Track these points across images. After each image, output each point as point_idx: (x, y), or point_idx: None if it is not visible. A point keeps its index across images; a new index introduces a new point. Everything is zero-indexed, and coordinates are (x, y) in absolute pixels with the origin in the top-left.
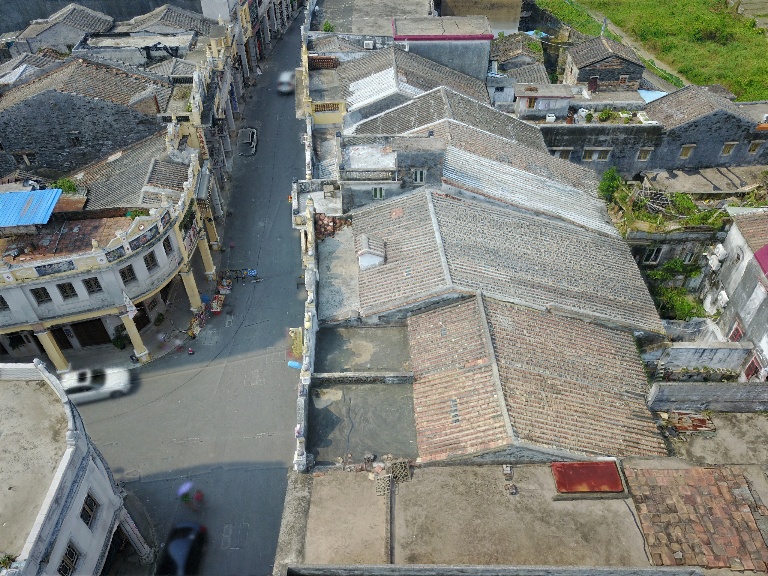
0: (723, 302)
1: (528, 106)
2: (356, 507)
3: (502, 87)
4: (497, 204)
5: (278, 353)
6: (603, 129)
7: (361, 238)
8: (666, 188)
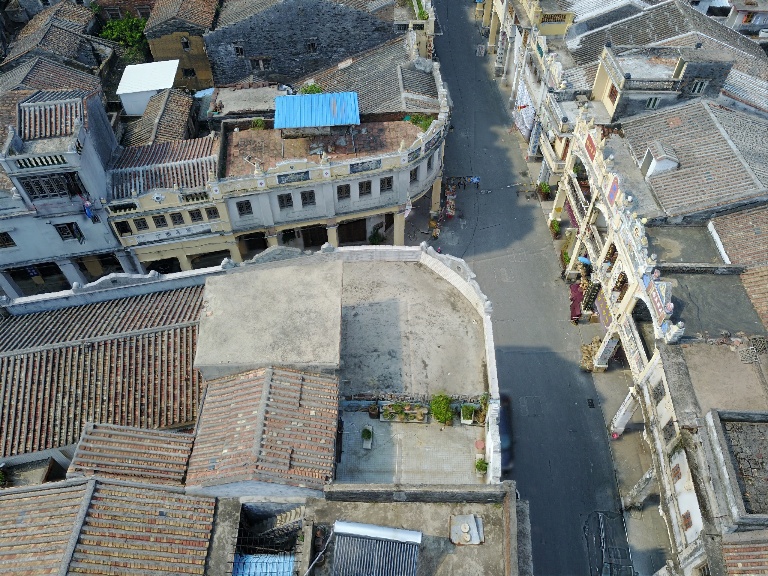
0: None
1: (744, 21)
2: (729, 372)
3: (698, 0)
4: (764, 116)
5: (518, 254)
6: None
7: (655, 145)
8: None
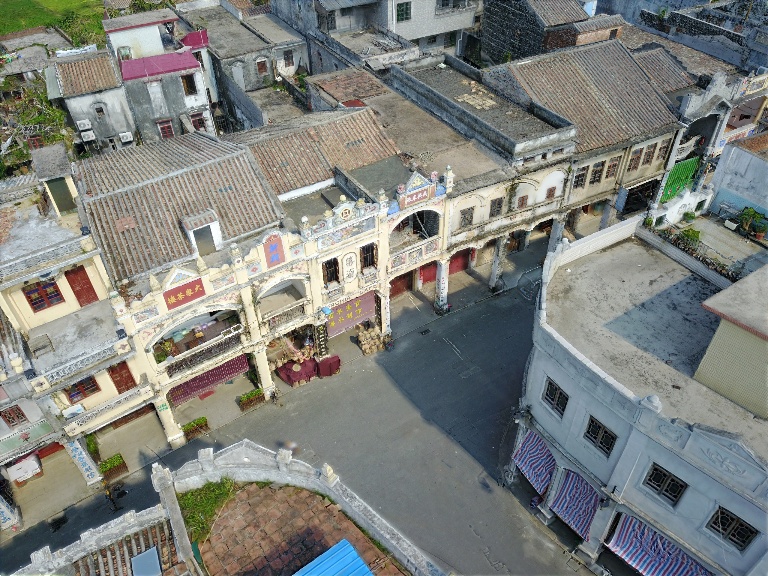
0: (131, 136)
1: None
2: None
3: None
4: None
5: None
6: None
7: (193, 221)
8: (1, 137)
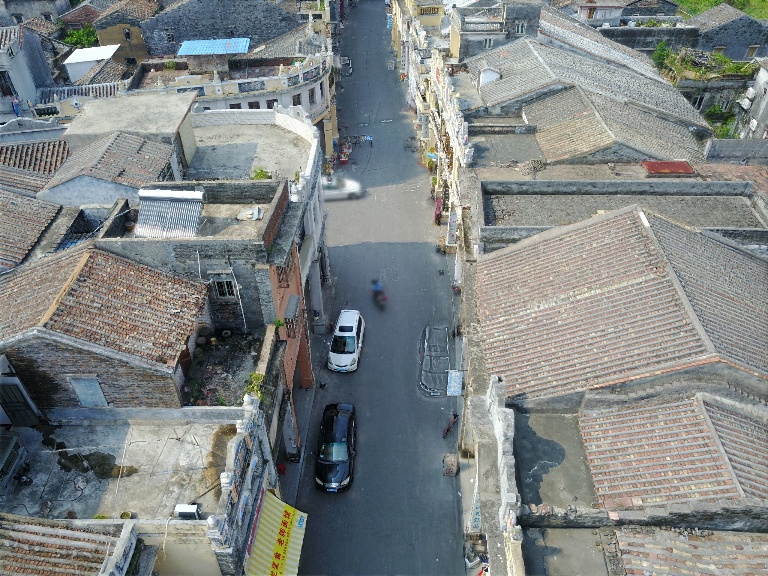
0: (754, 126)
1: (588, 17)
2: None
3: None
4: (578, 53)
5: (398, 185)
6: (650, 31)
7: (482, 63)
8: None
